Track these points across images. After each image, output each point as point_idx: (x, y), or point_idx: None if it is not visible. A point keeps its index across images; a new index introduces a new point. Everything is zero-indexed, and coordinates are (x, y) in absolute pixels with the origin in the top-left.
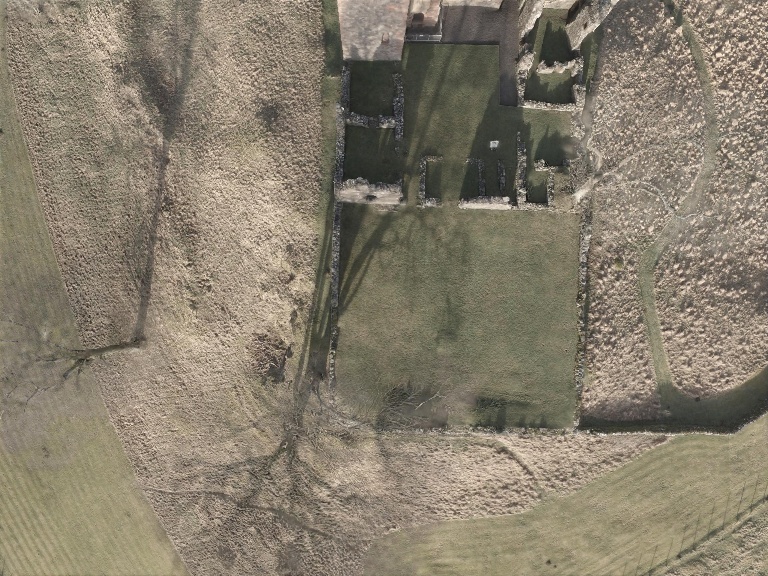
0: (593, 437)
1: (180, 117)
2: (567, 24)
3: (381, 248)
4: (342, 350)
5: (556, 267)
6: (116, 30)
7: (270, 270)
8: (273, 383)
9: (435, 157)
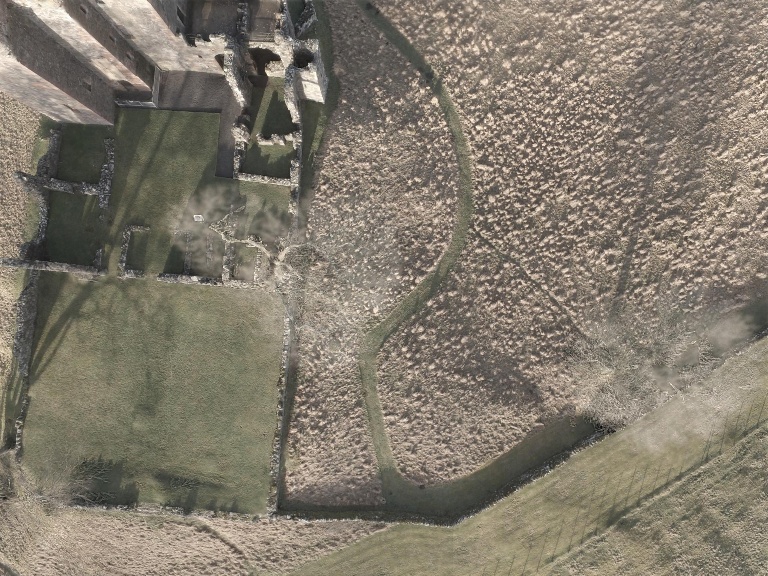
0: None
1: None
2: None
3: (79, 318)
4: (31, 420)
5: (260, 347)
6: None
7: None
8: None
9: (141, 227)
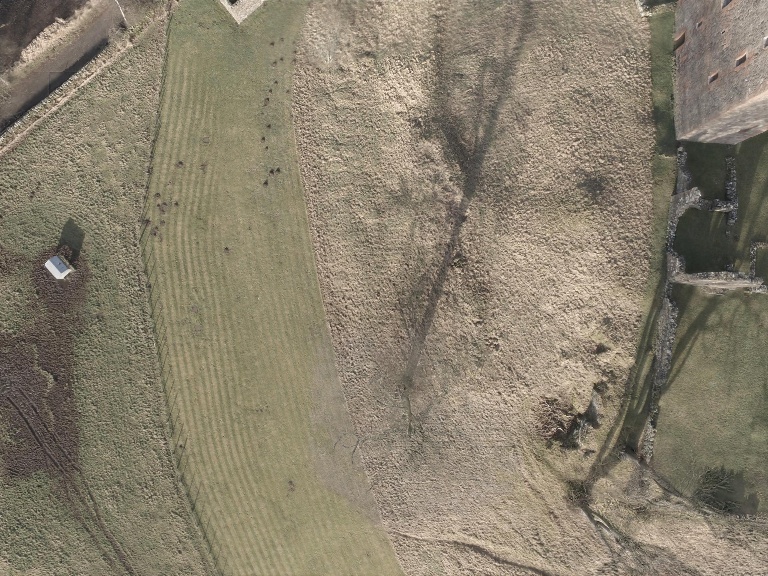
0: None
1: (480, 176)
2: None
3: (705, 330)
4: (661, 429)
5: None
6: (420, 86)
7: (575, 338)
8: (561, 448)
9: (765, 244)
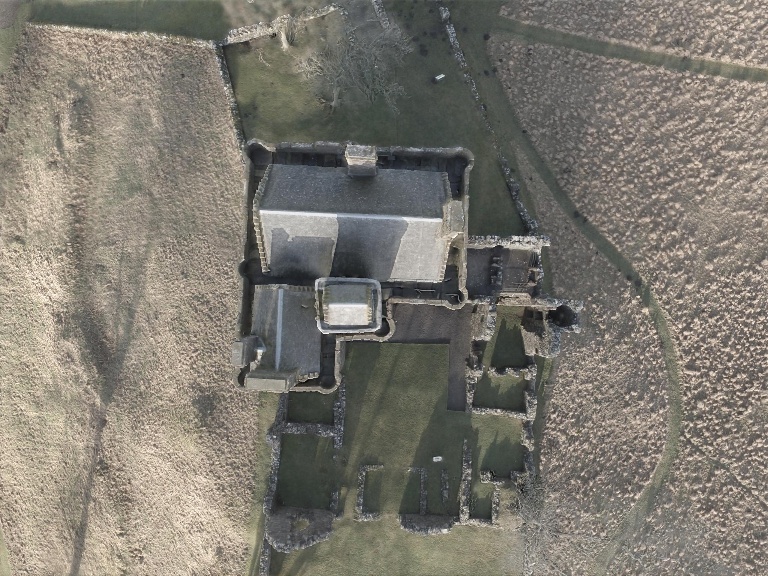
0: None
1: (119, 378)
2: (522, 325)
3: (314, 562)
4: None
5: None
6: (58, 280)
7: (201, 561)
8: None
9: (375, 466)
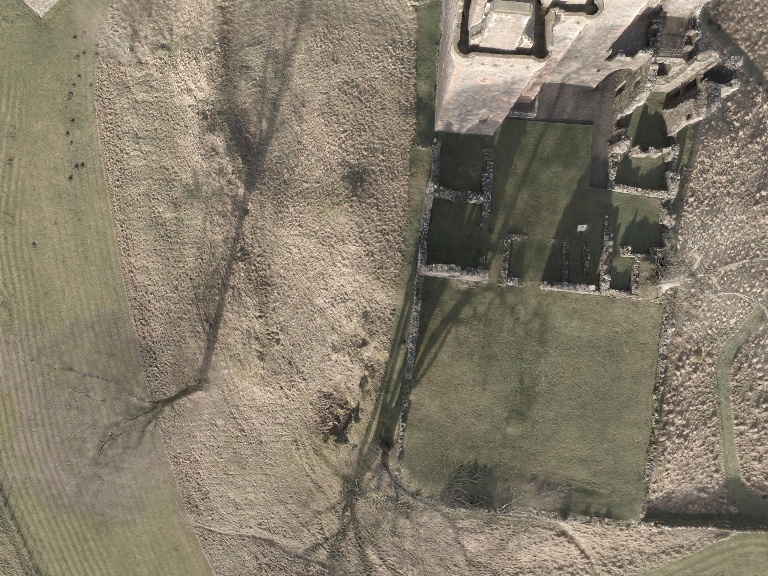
0: (656, 528)
1: (262, 169)
2: (665, 109)
3: (458, 323)
4: (412, 423)
5: (634, 356)
6: (205, 78)
7: (343, 332)
8: (335, 442)
9: (520, 236)
